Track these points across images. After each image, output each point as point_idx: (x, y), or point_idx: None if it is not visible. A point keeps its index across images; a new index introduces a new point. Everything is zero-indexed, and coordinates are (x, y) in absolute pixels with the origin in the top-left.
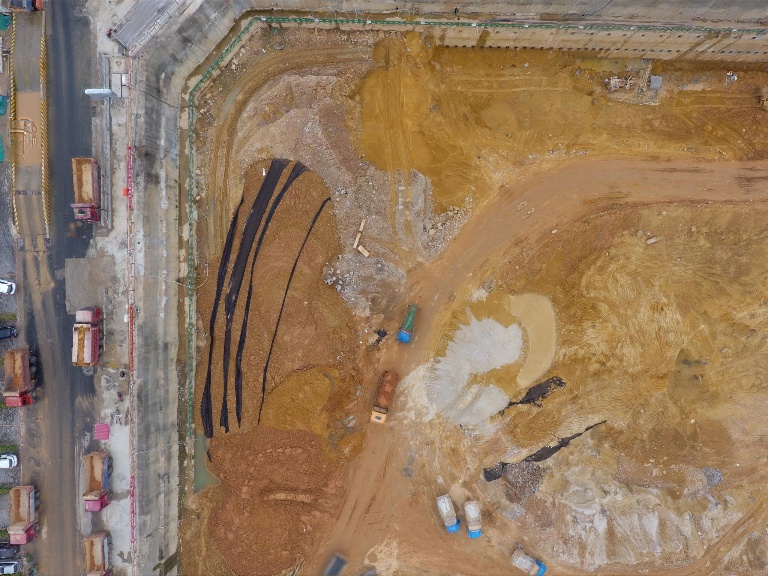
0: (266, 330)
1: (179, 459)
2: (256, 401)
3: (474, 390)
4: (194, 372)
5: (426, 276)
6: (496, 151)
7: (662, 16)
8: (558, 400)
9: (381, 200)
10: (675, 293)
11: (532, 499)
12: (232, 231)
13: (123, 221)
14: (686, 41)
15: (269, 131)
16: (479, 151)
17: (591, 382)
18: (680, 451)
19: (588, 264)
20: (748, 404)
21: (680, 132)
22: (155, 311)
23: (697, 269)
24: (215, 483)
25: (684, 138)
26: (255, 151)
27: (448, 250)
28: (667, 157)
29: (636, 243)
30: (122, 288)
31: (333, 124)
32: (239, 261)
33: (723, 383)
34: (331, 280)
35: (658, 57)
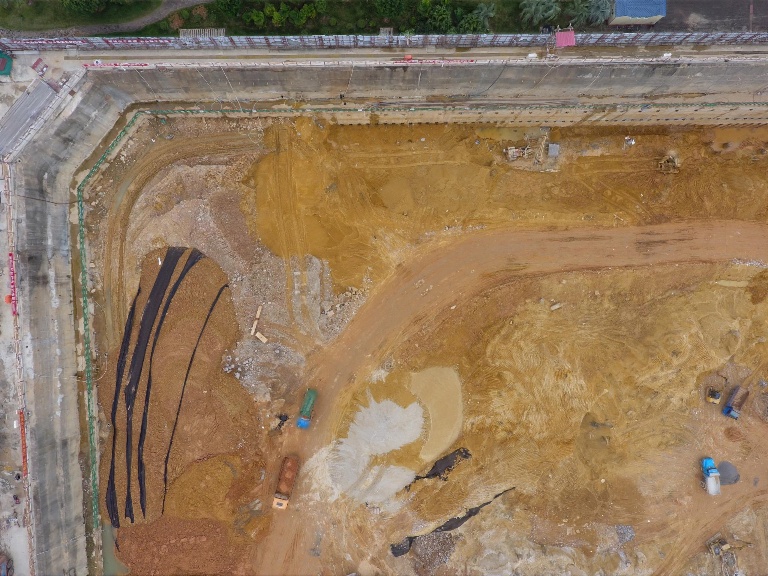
0: (166, 421)
1: (87, 550)
2: (159, 492)
3: (375, 471)
4: (98, 464)
5: (325, 359)
6: (392, 230)
7: (547, 94)
8: (464, 472)
9: (276, 286)
10: (581, 356)
11: (442, 570)
12: (130, 322)
13: (10, 326)
14: (575, 115)
15: (160, 222)
16: (375, 231)
17: (497, 451)
18: (591, 511)
19: (493, 333)
20: (657, 461)
21: (579, 199)
22: (50, 410)
23: (602, 332)
24: (125, 571)
25: (583, 205)
26: (149, 241)
27: (346, 332)
28: (565, 227)
29: (540, 310)
30: (13, 392)
31: (226, 211)
32: (137, 352)
33: (630, 444)
34: (229, 368)
35: (555, 125)
